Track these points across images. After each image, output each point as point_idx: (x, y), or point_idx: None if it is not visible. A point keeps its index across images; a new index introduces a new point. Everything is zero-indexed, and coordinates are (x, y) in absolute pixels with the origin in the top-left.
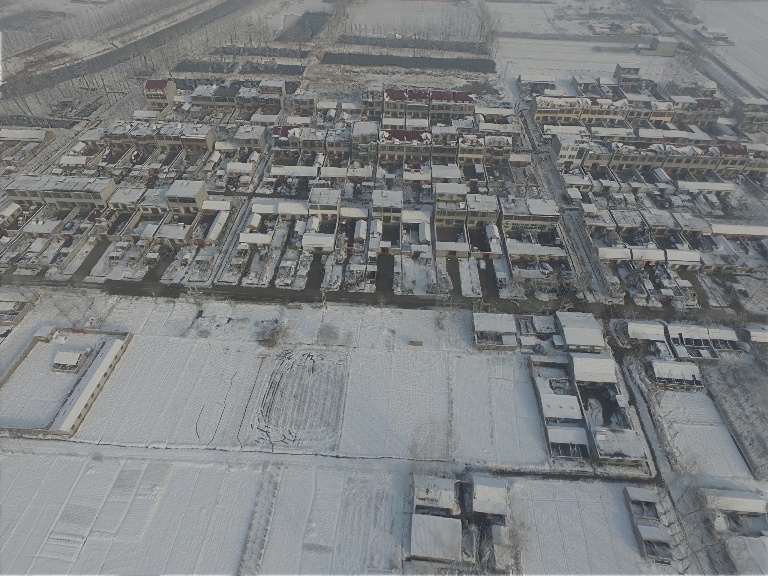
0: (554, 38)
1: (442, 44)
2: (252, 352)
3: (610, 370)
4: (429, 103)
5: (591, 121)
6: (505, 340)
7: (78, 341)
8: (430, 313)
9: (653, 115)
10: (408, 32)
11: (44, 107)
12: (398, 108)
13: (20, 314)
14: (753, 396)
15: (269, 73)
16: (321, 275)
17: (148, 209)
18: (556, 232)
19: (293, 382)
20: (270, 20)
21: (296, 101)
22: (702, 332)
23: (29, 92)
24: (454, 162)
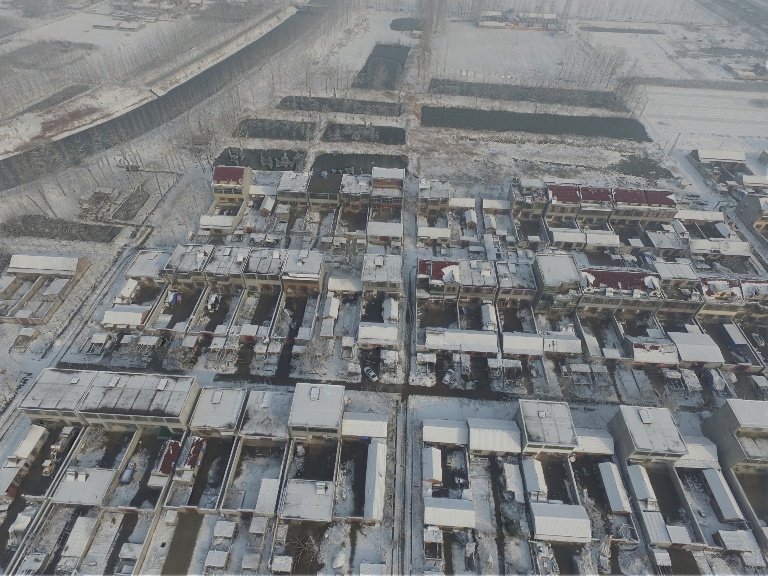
0: (696, 86)
1: (575, 99)
2: None
3: None
4: (613, 207)
5: None
6: None
7: None
8: None
9: None
10: (529, 82)
11: (71, 201)
12: (567, 212)
13: None
14: None
15: (362, 141)
16: None
17: None
18: None
19: None
20: (338, 55)
21: (423, 199)
22: None
23: None
24: (691, 320)
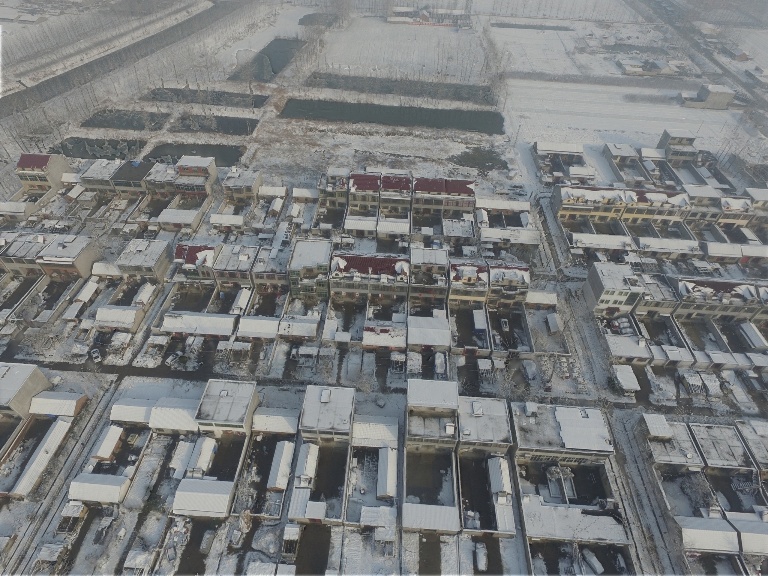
0: (576, 81)
1: (436, 92)
2: None
3: None
4: (412, 196)
5: (636, 221)
6: None
7: None
8: None
9: (723, 217)
10: (393, 75)
11: None
12: (369, 200)
13: None
14: None
15: (207, 132)
16: None
17: None
18: (604, 473)
19: None
20: (229, 49)
21: (227, 187)
22: None
23: None
24: (442, 306)
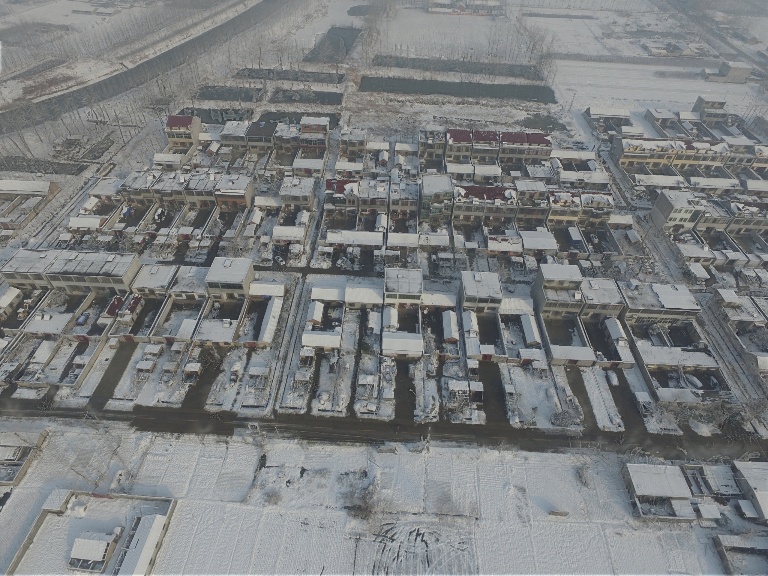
0: (610, 60)
1: (494, 69)
2: (341, 529)
3: None
4: (500, 146)
5: (683, 167)
6: (677, 508)
7: (102, 512)
8: (565, 458)
9: (757, 161)
10: (455, 54)
11: (46, 146)
12: (462, 151)
13: (22, 468)
14: None
15: (303, 102)
16: (412, 395)
17: (182, 295)
18: (693, 328)
19: None
20: (294, 36)
21: (343, 142)
22: None
23: (28, 126)
24: (543, 225)
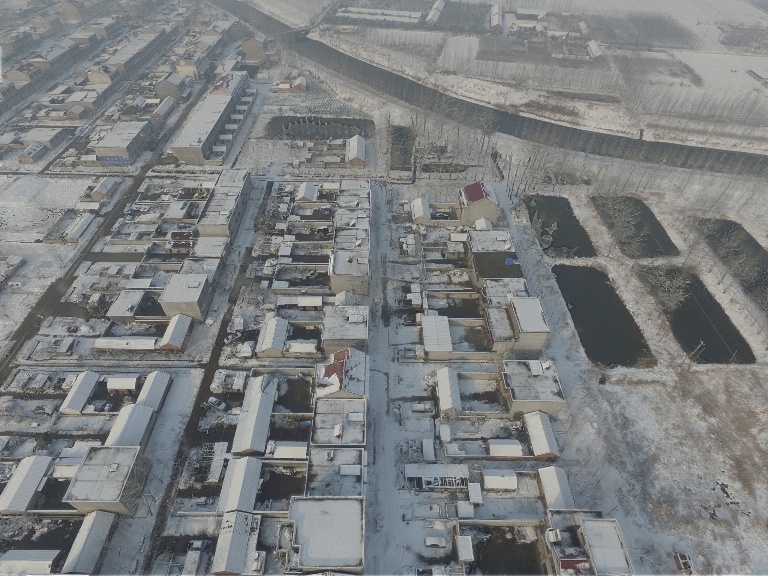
0: None
1: None
2: None
3: None
4: None
5: None
6: None
7: None
8: None
9: None
10: None
11: None
12: None
13: (51, 240)
14: None
15: None
16: None
17: None
18: None
19: None
20: None
21: None
22: None
23: None
24: None
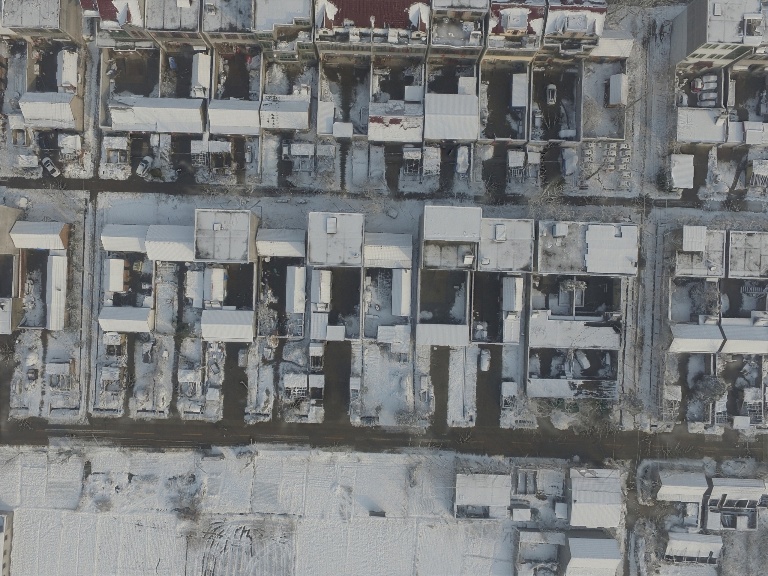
0: None
1: None
2: (172, 529)
3: (612, 566)
4: None
5: None
6: (493, 511)
7: None
8: (399, 458)
9: None
10: None
11: None
12: None
13: None
14: (767, 575)
15: None
16: (243, 390)
17: None
18: (618, 285)
19: (230, 571)
20: None
21: None
22: (755, 493)
23: None
24: (472, 69)
